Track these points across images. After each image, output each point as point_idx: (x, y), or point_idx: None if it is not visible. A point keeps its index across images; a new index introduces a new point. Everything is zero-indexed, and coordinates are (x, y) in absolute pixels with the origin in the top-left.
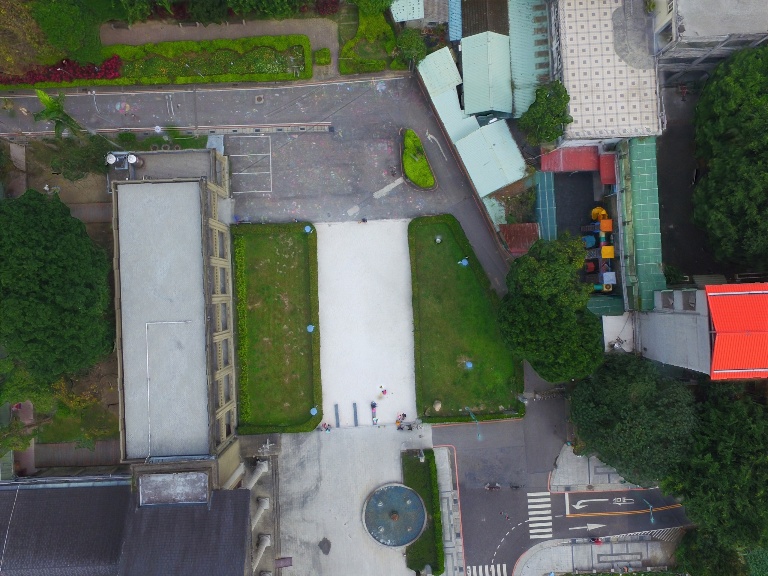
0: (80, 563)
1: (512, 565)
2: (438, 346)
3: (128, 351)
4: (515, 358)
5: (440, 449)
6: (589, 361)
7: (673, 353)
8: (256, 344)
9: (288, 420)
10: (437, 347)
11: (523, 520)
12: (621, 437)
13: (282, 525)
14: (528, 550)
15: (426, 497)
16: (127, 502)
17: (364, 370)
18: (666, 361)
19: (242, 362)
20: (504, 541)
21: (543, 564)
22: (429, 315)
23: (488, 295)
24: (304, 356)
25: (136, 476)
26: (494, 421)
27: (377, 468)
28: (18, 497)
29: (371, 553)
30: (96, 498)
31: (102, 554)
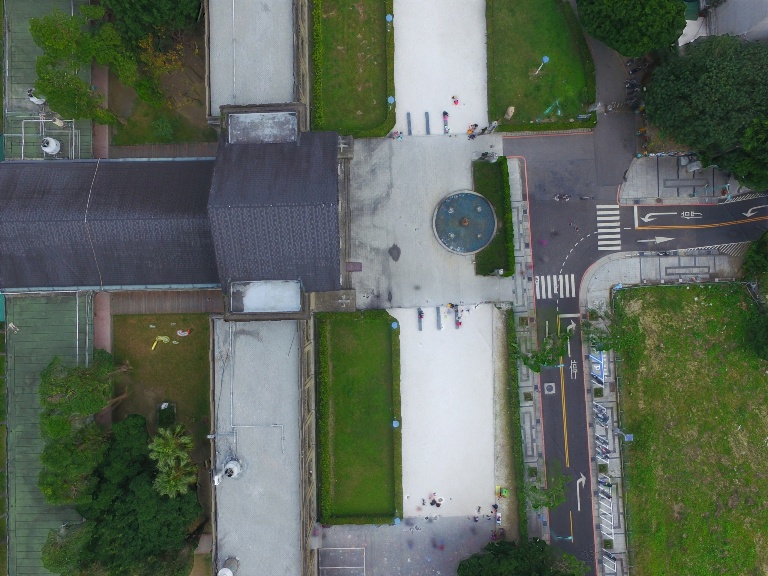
0: (164, 216)
1: (580, 276)
2: (510, 59)
3: (214, 12)
4: (587, 68)
5: (511, 160)
6: (675, 16)
7: (758, 11)
8: (330, 52)
9: (360, 127)
10: (509, 60)
11: (592, 231)
12: (707, 85)
13: (353, 230)
14: (596, 262)
15: (497, 202)
16: (208, 172)
17: (436, 81)
18: (749, 28)
19: (316, 68)
20: (573, 252)
21: (611, 275)
22: (502, 28)
23: (561, 9)
24: (377, 65)
25: (226, 111)
26: (565, 134)
27: (448, 177)
28: (99, 167)
29: (440, 260)
30: (177, 169)
31: (185, 210)
